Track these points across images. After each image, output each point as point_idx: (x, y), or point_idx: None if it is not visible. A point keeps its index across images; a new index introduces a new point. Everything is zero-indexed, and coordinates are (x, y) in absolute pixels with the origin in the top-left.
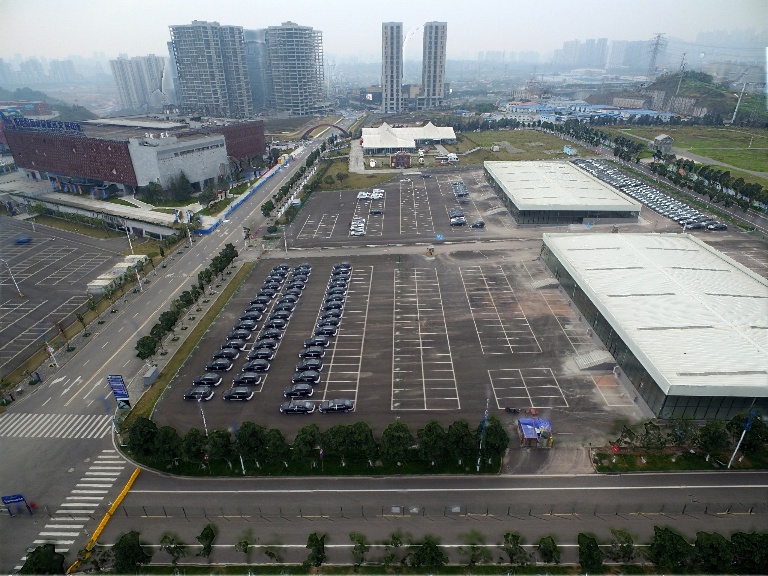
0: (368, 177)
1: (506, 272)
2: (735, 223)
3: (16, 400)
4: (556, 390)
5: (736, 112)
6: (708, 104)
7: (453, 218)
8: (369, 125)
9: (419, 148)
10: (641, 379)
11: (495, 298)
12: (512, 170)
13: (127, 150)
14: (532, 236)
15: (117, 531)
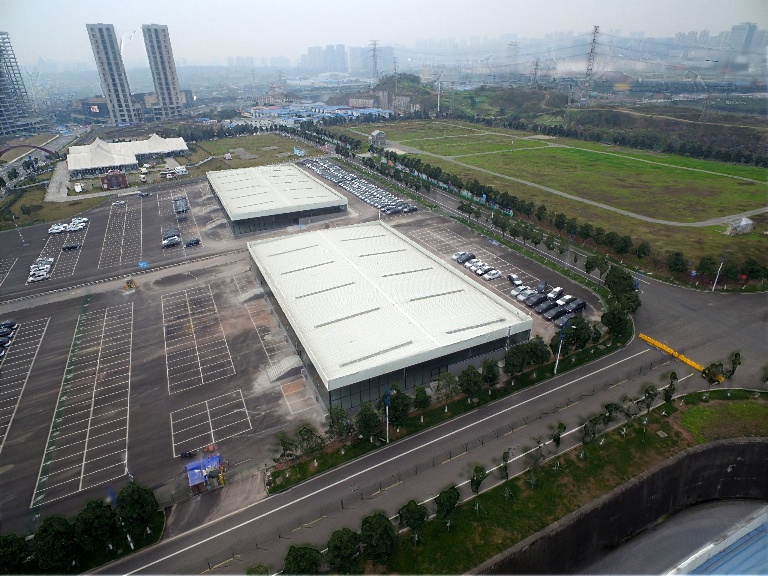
0: (70, 205)
1: (214, 291)
2: (424, 204)
3: None
4: (242, 413)
5: (439, 107)
6: (419, 101)
7: (166, 239)
8: (89, 142)
9: (144, 163)
10: (316, 378)
11: (196, 323)
12: (234, 178)
13: None
14: None
15: None
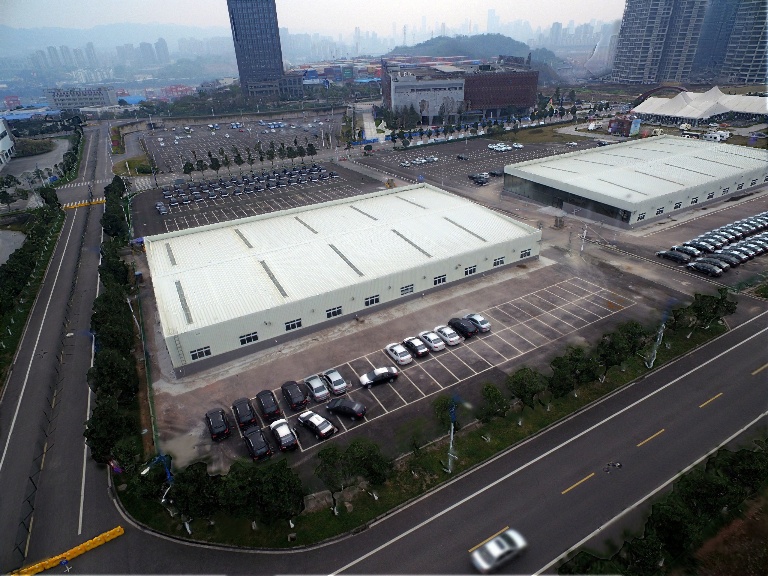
0: (553, 136)
1: None
2: None
3: (158, 174)
4: None
5: None
6: None
7: None
8: None
9: None
10: None
11: None
12: (660, 147)
13: (390, 84)
14: (486, 201)
15: (83, 207)
